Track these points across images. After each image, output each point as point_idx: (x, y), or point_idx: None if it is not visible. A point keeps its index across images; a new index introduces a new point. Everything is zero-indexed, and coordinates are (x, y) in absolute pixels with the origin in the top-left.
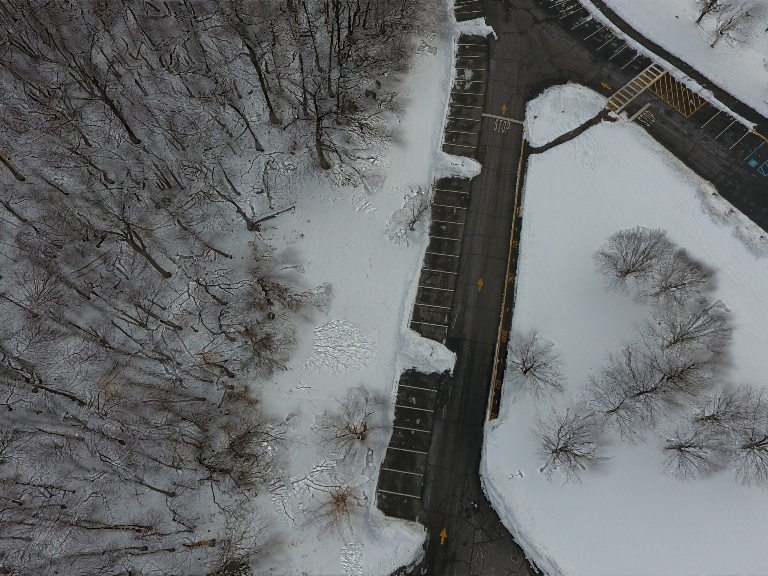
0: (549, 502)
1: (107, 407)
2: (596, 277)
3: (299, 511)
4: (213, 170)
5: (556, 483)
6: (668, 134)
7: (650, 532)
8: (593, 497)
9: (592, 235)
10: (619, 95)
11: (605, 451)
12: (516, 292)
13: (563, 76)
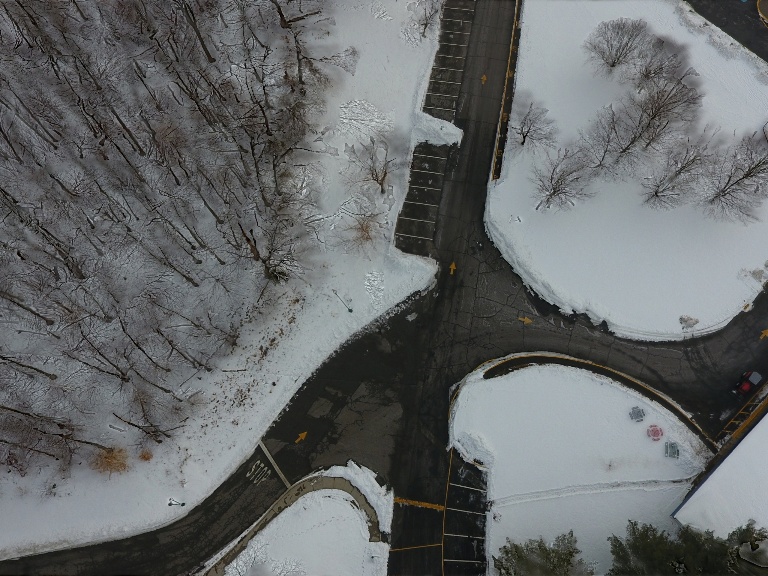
0: (544, 241)
1: None
2: (585, 66)
3: (330, 235)
4: None
5: (550, 227)
6: None
7: (630, 265)
8: (582, 238)
9: None
10: None
11: (592, 203)
12: (515, 84)
13: None
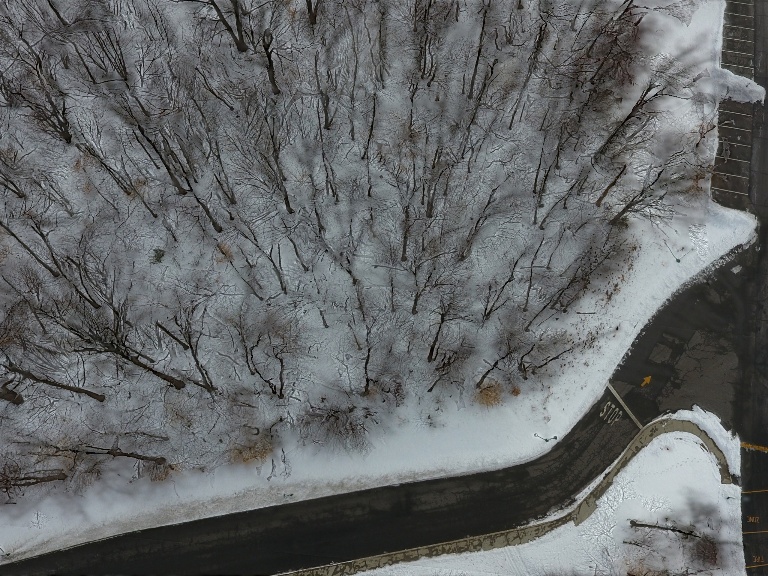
0: None
1: (494, 98)
2: None
3: None
4: None
5: None
6: None
7: None
8: None
9: None
10: None
11: None
12: None
13: None
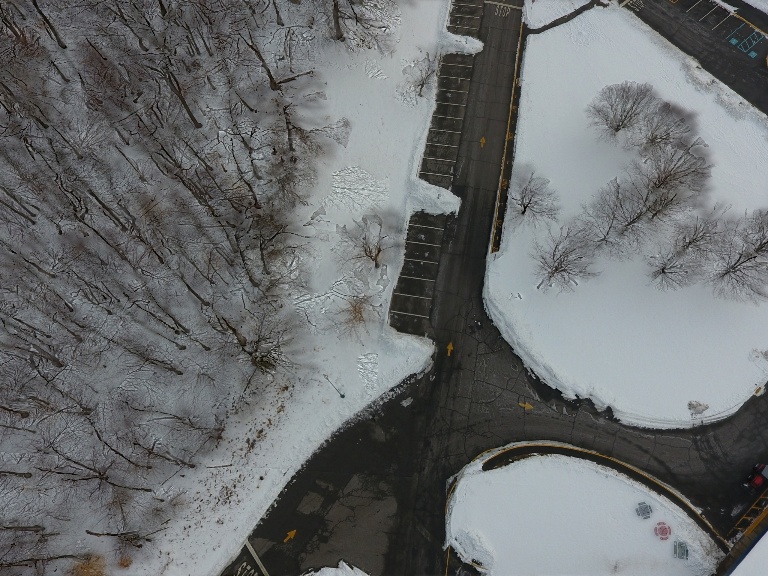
0: (545, 320)
1: None
2: (588, 130)
3: (321, 318)
4: (238, 40)
5: (552, 304)
6: (656, 17)
7: (636, 345)
8: (585, 316)
9: (585, 101)
10: None
11: (596, 278)
12: (515, 148)
13: None
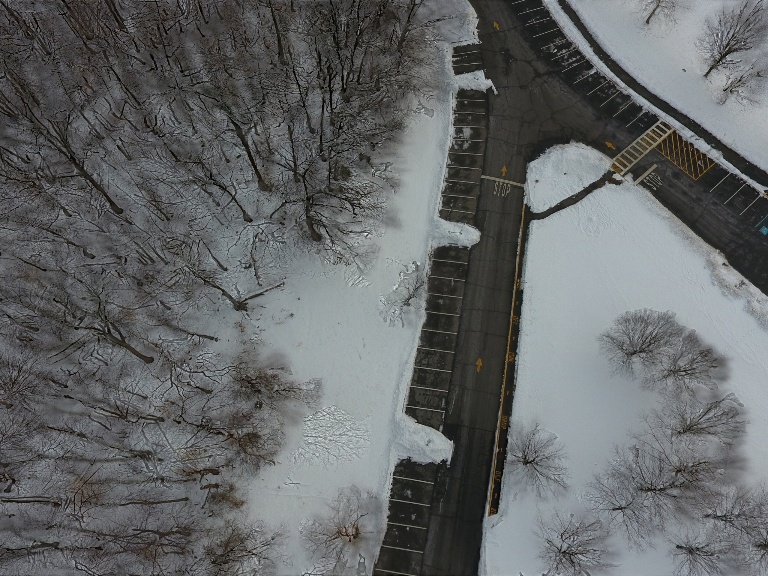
0: None
1: (83, 509)
2: (601, 360)
3: None
4: (199, 243)
5: None
6: (675, 198)
7: None
8: None
9: (596, 310)
10: (624, 155)
11: (611, 550)
12: (517, 373)
13: (566, 134)
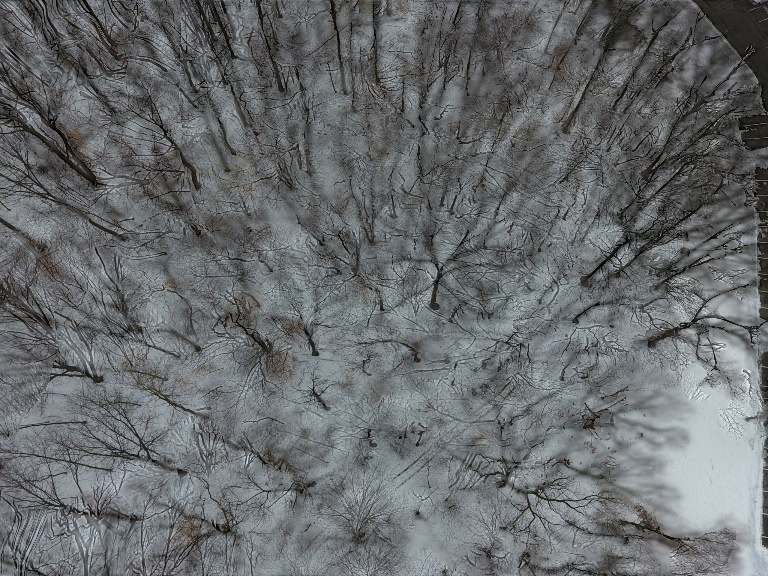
0: None
1: None
2: None
3: None
4: (528, 347)
5: None
6: None
7: None
8: None
9: None
10: None
11: None
12: None
13: None
